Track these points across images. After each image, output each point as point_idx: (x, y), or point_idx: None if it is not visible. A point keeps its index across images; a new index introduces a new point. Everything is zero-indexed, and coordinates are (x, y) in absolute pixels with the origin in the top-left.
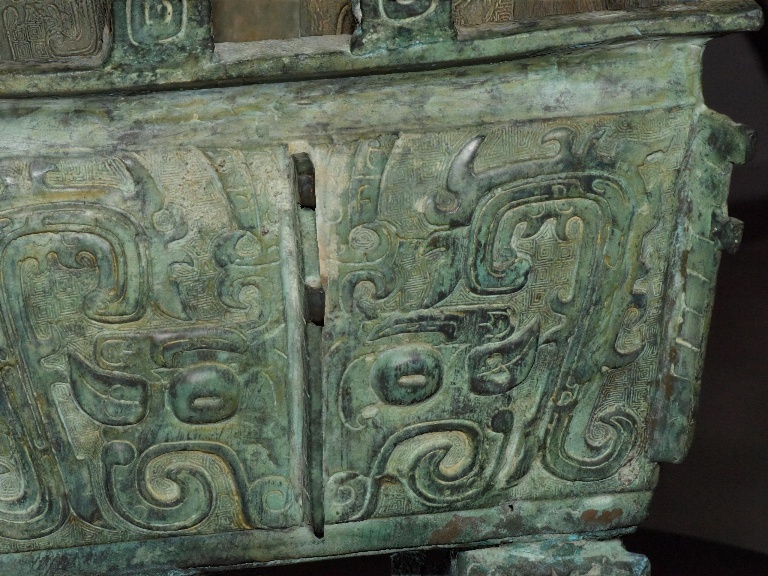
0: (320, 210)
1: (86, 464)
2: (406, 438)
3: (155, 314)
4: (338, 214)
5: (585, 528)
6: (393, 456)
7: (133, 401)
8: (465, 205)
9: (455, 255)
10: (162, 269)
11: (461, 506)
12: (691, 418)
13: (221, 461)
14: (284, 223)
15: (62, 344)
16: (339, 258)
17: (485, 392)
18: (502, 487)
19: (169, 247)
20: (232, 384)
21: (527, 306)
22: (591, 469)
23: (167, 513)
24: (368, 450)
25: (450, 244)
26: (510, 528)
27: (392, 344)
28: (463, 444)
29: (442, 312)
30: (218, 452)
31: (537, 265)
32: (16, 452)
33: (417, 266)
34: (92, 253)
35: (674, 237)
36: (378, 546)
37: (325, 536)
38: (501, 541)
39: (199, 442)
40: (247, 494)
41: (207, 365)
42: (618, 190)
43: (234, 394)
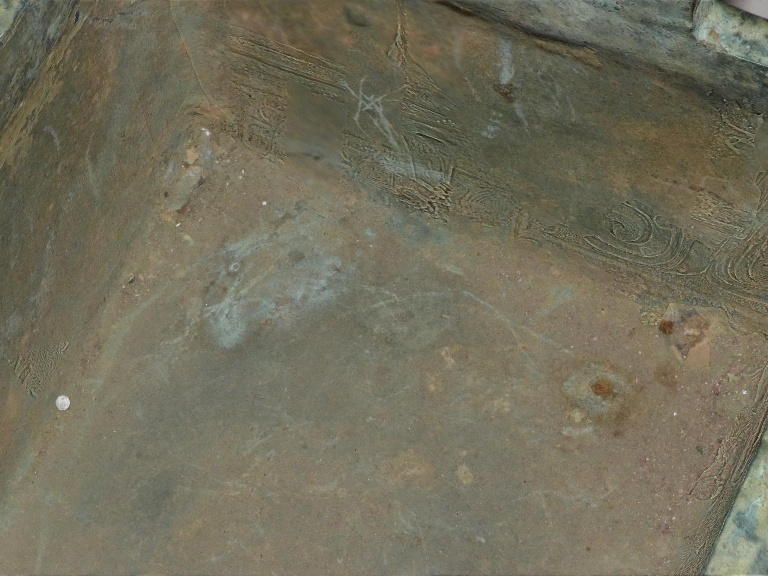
0: None
1: None
2: None
3: None
4: None
5: None
6: None
7: None
8: None
9: None
10: None
11: None
12: None
13: None
14: None
15: None
16: None
17: None
18: None
19: None
20: None
21: None
22: None
23: None
24: None
25: None
26: None
27: None
28: None
29: None
30: None
31: None
32: (760, 251)
33: None
34: None
35: None
36: None
37: None
38: None
39: None
40: None
41: None
42: None
43: None
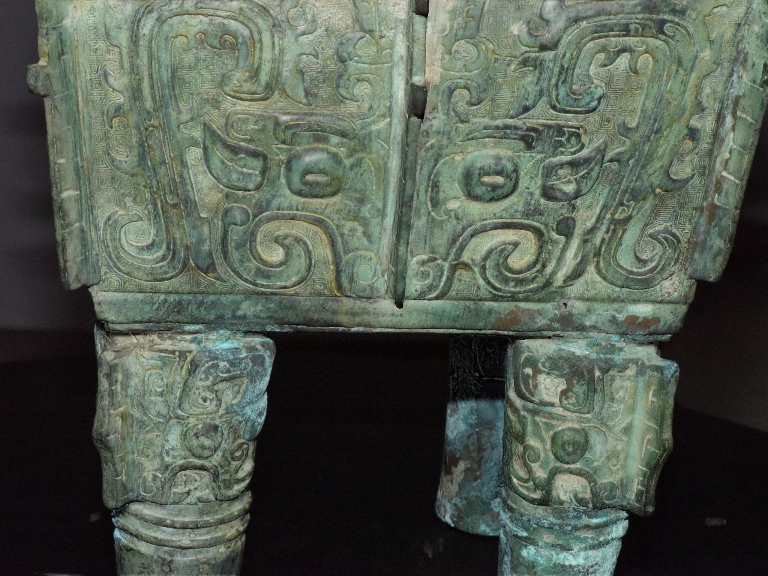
0: (431, 22)
1: (208, 222)
2: (482, 231)
3: (281, 97)
4: (445, 28)
5: (627, 331)
6: (469, 246)
7: (254, 171)
8: (554, 32)
9: (541, 75)
10: (291, 58)
11: (522, 298)
12: (728, 242)
13: (322, 233)
14: (399, 31)
15: (200, 114)
16: (442, 66)
17: (554, 199)
18: (559, 285)
19: (299, 40)
20: (339, 166)
21: (597, 127)
22: (637, 278)
23: (271, 273)
24: (448, 238)
25: (538, 65)
26: (562, 323)
27: (479, 147)
28: (530, 243)
29: (525, 123)
30: (321, 224)
31: (610, 92)
32: (150, 204)
33: (508, 81)
34: (234, 37)
35: (729, 83)
36: (448, 325)
37: (403, 310)
38: (553, 334)
39: (306, 214)
40: (341, 264)
41: (320, 147)
42: (686, 35)
43: (340, 174)
